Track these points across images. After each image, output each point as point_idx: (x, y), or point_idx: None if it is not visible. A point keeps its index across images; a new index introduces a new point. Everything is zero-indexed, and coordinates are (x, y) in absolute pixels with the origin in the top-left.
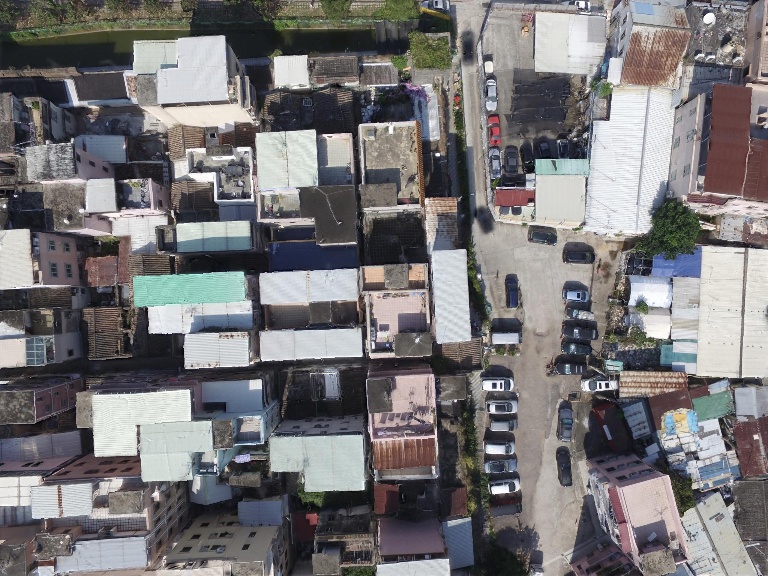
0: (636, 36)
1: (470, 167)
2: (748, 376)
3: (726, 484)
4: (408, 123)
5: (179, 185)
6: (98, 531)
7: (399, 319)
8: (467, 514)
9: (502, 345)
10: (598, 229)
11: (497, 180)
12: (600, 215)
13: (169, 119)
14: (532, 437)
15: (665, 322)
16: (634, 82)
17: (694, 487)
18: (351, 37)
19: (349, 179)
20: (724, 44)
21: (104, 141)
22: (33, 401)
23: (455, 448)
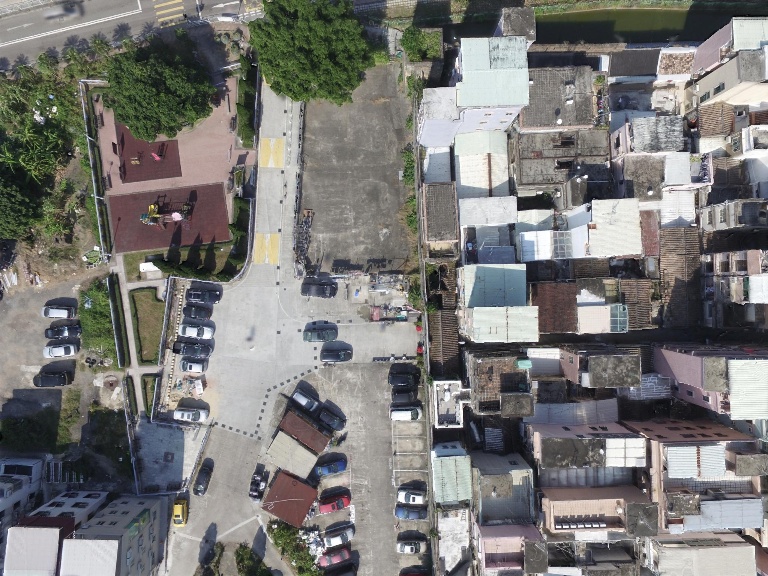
0: None
1: None
2: None
3: None
4: None
5: (714, 161)
6: (705, 493)
7: None
8: None
9: None
10: None
11: None
12: None
13: (728, 96)
14: None
15: None
16: None
17: None
18: None
19: None
20: None
21: (641, 116)
22: (639, 366)
23: None
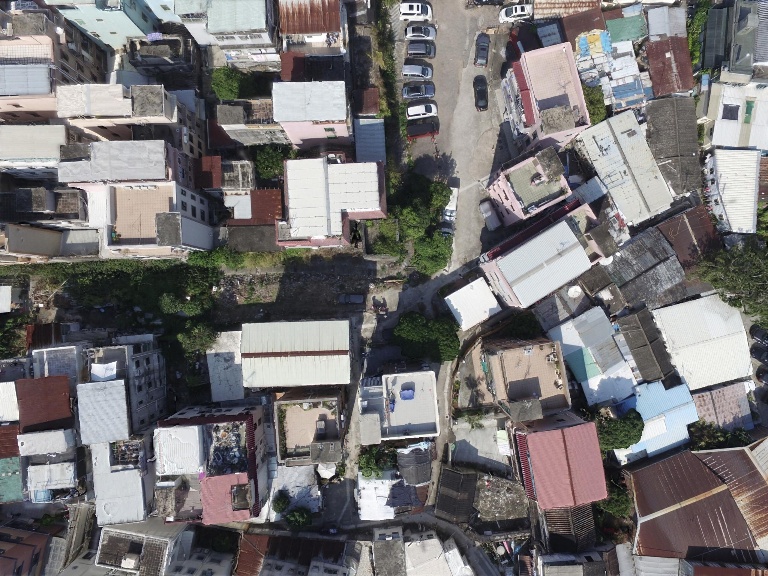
0: None
1: None
2: None
3: (640, 108)
4: None
5: None
6: None
7: None
8: (379, 113)
9: None
10: None
11: None
12: None
13: None
14: (450, 67)
15: None
16: None
17: (606, 103)
18: None
19: None
20: None
21: None
22: None
23: (369, 54)
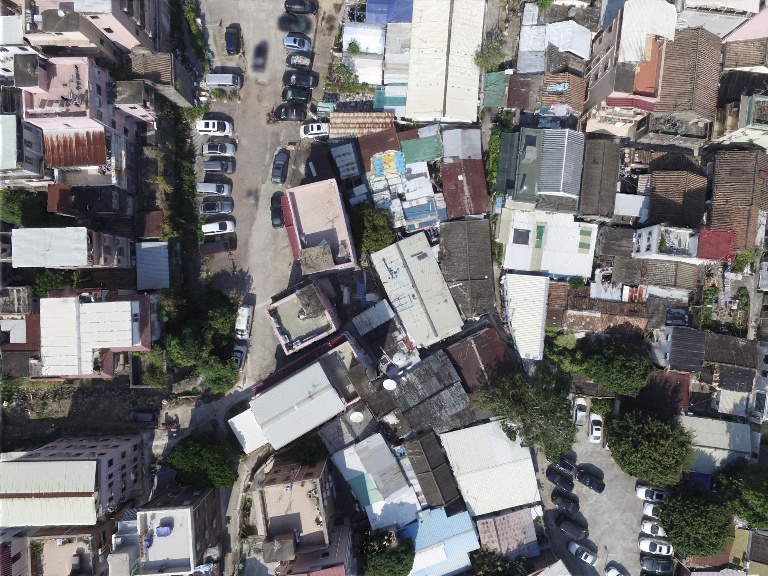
0: None
1: None
2: (453, 116)
3: (436, 229)
4: None
5: None
6: None
7: (60, 8)
8: (162, 237)
9: (223, 92)
10: None
11: None
12: None
13: None
14: (249, 182)
15: (376, 65)
16: None
17: (397, 225)
18: None
19: None
20: None
21: None
22: None
23: (156, 175)
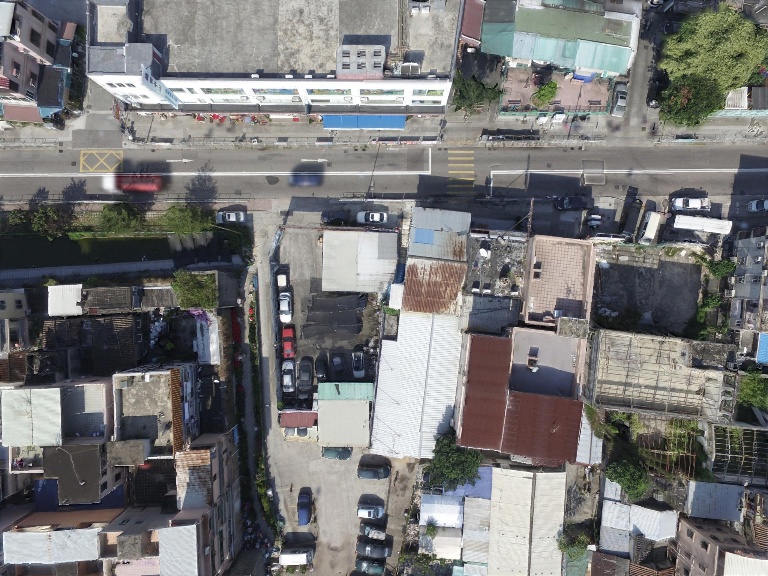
0: (412, 268)
1: (265, 378)
2: None
3: None
4: (162, 373)
5: None
6: None
7: None
8: None
9: None
10: (384, 453)
11: (280, 403)
12: (386, 438)
13: None
14: None
15: (455, 545)
16: (415, 310)
17: None
18: (148, 245)
19: (102, 429)
20: (501, 277)
21: None
22: None
23: None
